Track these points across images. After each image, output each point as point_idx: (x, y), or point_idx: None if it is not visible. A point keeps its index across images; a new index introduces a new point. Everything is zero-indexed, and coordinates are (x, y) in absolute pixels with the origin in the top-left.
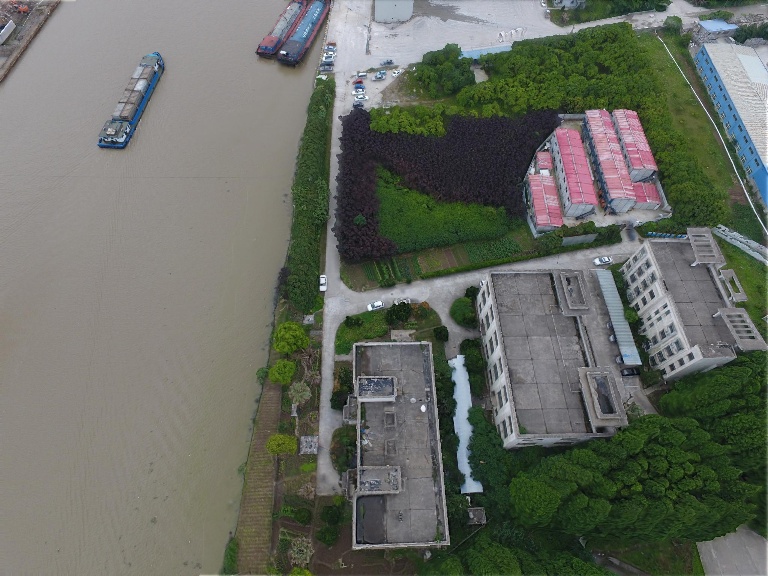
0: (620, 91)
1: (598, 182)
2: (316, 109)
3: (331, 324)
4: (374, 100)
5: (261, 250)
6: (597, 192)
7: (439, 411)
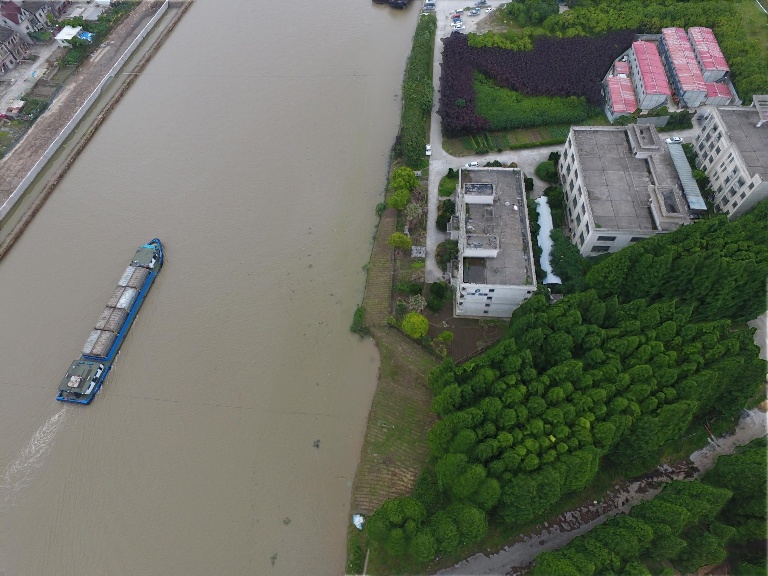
0: (696, 12)
1: (672, 84)
2: (422, 33)
3: (435, 177)
4: (470, 29)
5: (377, 131)
6: (671, 92)
7: None
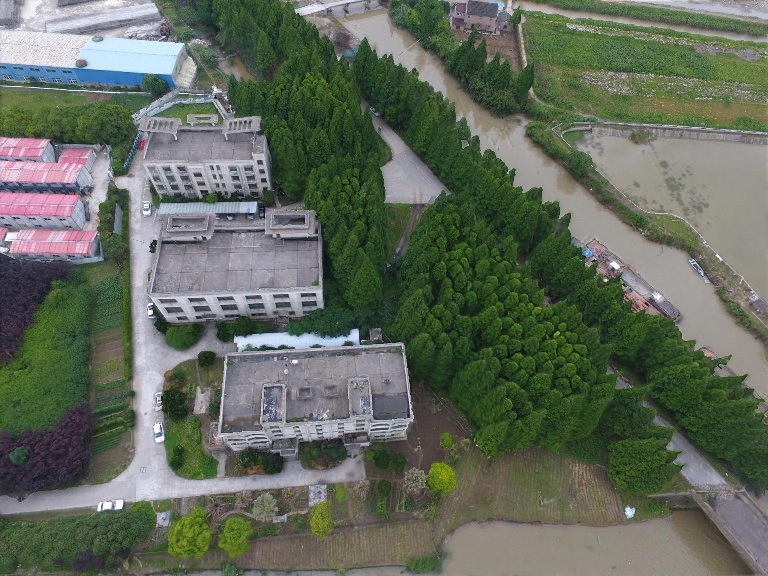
0: None
1: None
2: None
3: (175, 488)
4: None
5: None
6: None
7: None
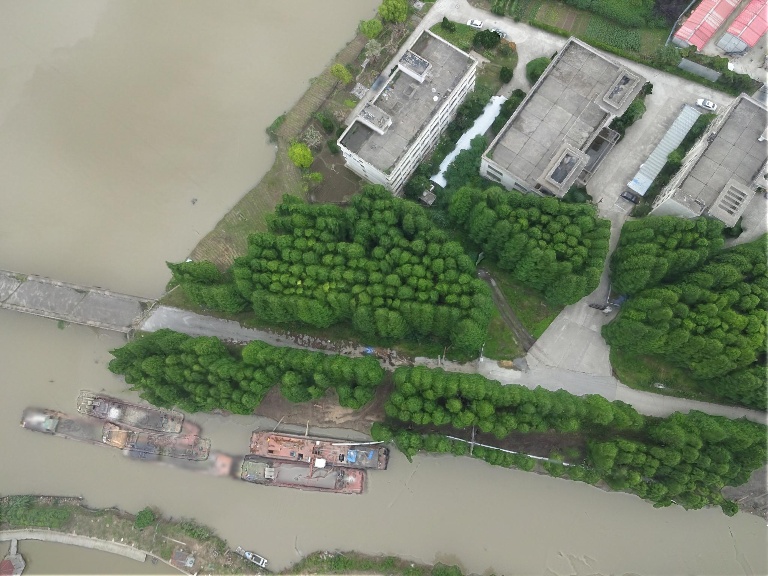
0: None
1: None
2: None
3: (432, 18)
4: None
5: None
6: None
7: (457, 123)
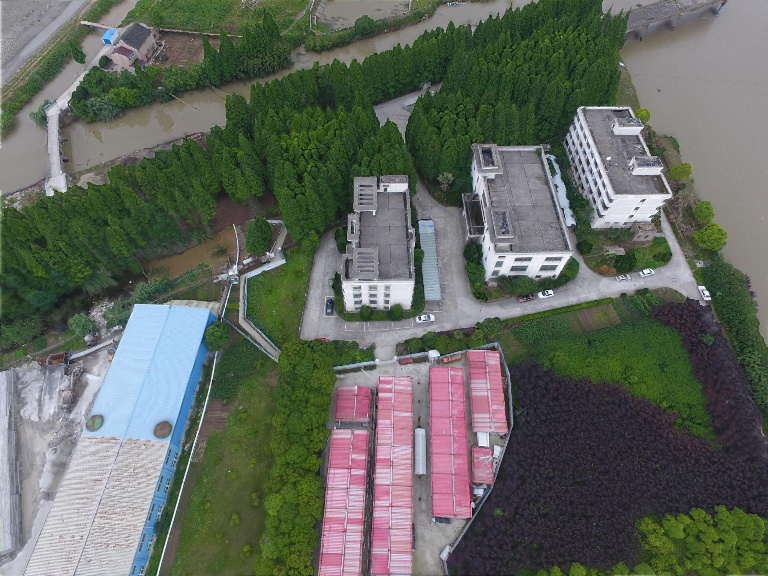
0: None
1: None
2: None
3: (679, 260)
4: None
5: None
6: None
7: None
